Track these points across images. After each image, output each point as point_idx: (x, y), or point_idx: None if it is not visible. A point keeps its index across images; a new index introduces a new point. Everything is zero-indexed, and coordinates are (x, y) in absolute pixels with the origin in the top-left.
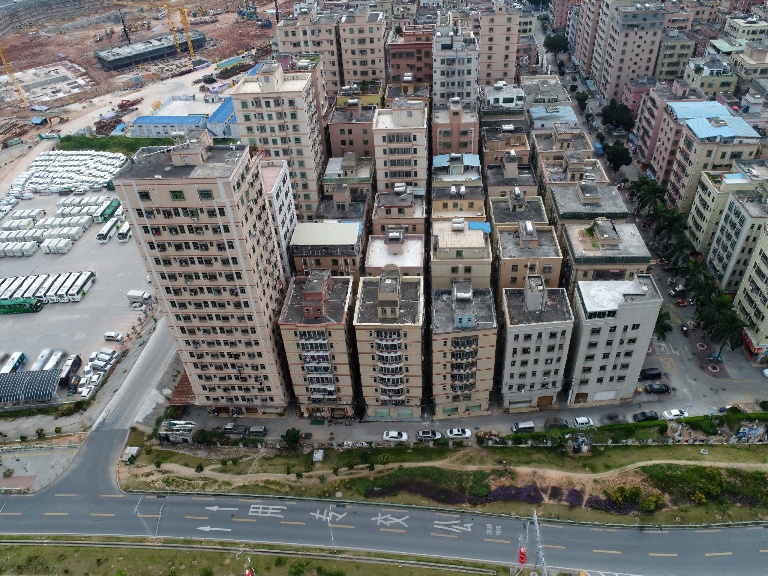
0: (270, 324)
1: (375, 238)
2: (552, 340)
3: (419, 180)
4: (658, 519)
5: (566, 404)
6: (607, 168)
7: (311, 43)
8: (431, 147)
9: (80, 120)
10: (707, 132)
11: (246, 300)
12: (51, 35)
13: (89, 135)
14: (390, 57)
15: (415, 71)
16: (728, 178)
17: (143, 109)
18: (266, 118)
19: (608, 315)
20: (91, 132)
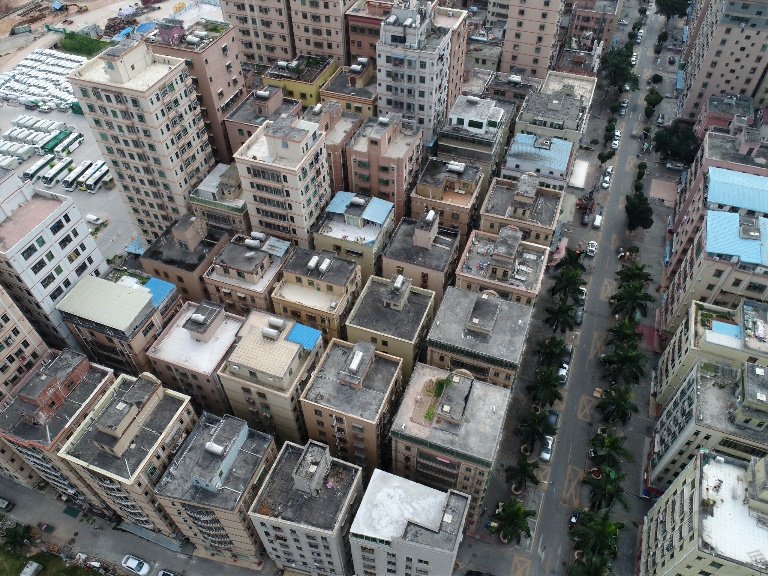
0: None
1: (193, 306)
2: None
3: (297, 227)
4: None
5: None
6: (626, 219)
7: None
8: (347, 174)
9: (99, 12)
10: (723, 244)
11: None
12: None
13: (95, 34)
14: (349, 30)
15: None
16: (714, 331)
17: (166, 9)
18: (111, 114)
19: (381, 541)
20: (98, 31)
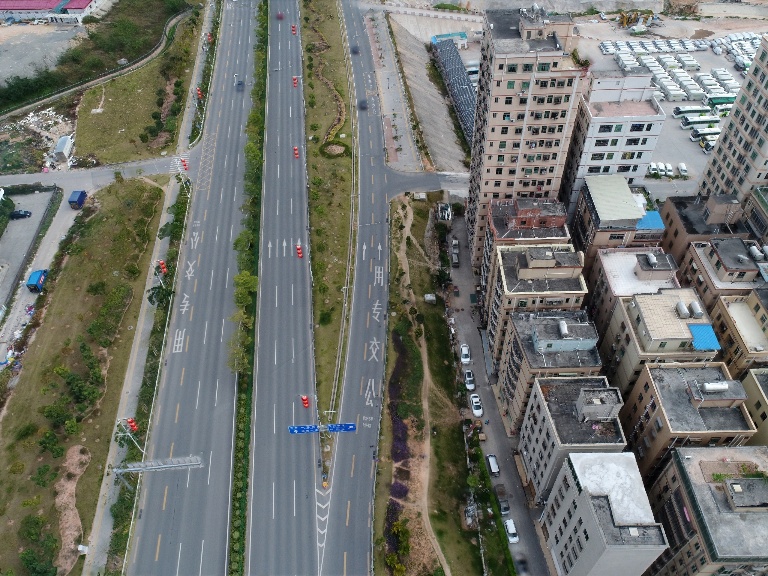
0: None
1: None
2: None
3: None
4: (381, 570)
5: (539, 518)
6: None
7: None
8: None
9: None
10: None
11: None
12: None
13: None
14: None
15: None
16: None
17: None
18: (764, 83)
19: None
20: None
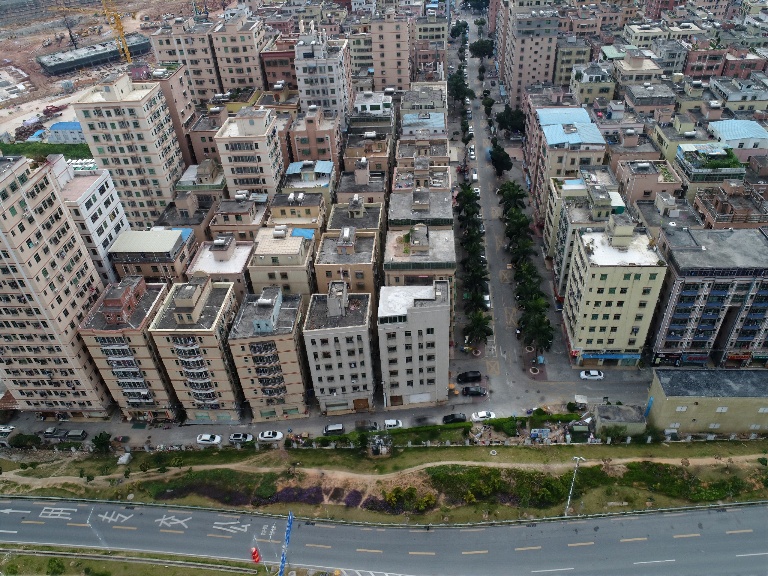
0: (72, 330)
1: (208, 245)
2: (350, 344)
3: (268, 187)
4: (427, 519)
5: (383, 407)
6: (494, 173)
7: (186, 51)
8: (292, 154)
9: (3, 126)
10: (557, 139)
11: (36, 307)
12: (2, 40)
13: (7, 141)
14: (265, 65)
15: (291, 79)
16: (567, 184)
17: (67, 115)
18: (109, 127)
19: (400, 320)
20: (9, 138)
